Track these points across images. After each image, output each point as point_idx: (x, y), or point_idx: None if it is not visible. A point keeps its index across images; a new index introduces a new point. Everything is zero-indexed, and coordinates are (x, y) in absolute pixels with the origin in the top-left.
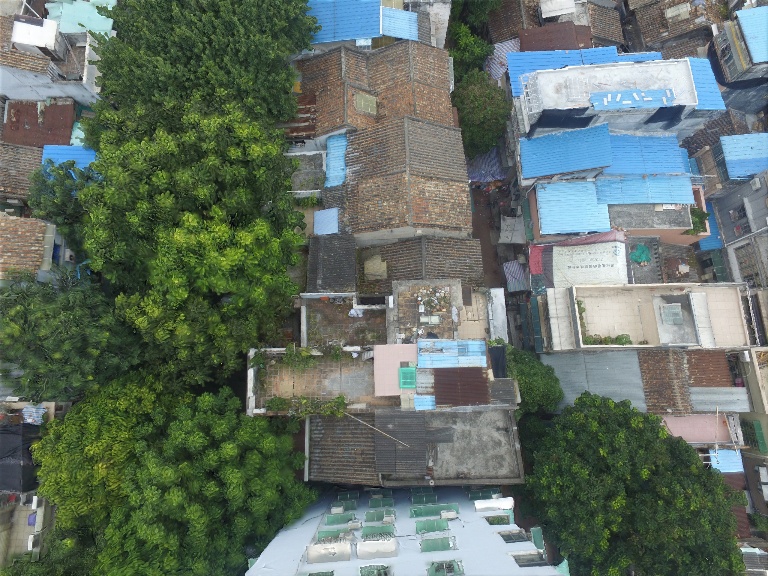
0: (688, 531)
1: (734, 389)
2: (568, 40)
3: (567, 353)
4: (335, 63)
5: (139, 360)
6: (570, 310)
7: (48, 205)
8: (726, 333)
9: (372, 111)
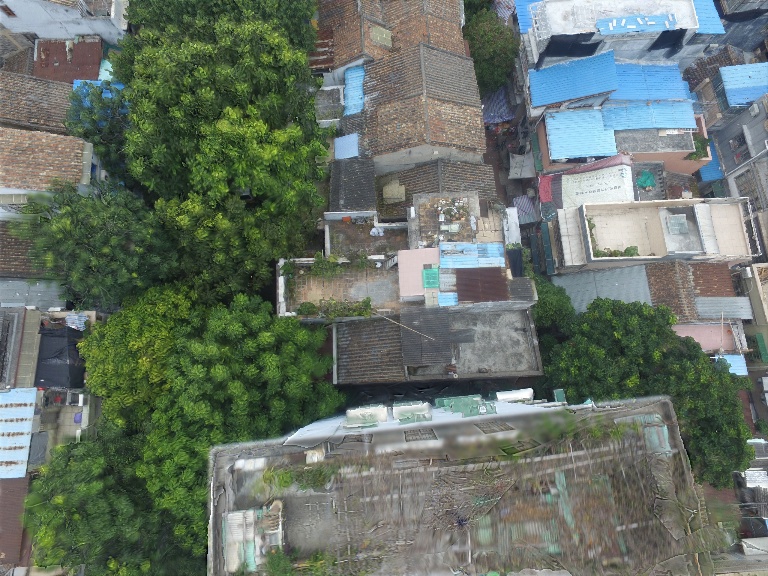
0: (699, 402)
1: (737, 298)
2: None
3: (577, 273)
4: None
5: (178, 263)
6: (580, 228)
7: (86, 122)
8: (729, 246)
9: (387, 44)
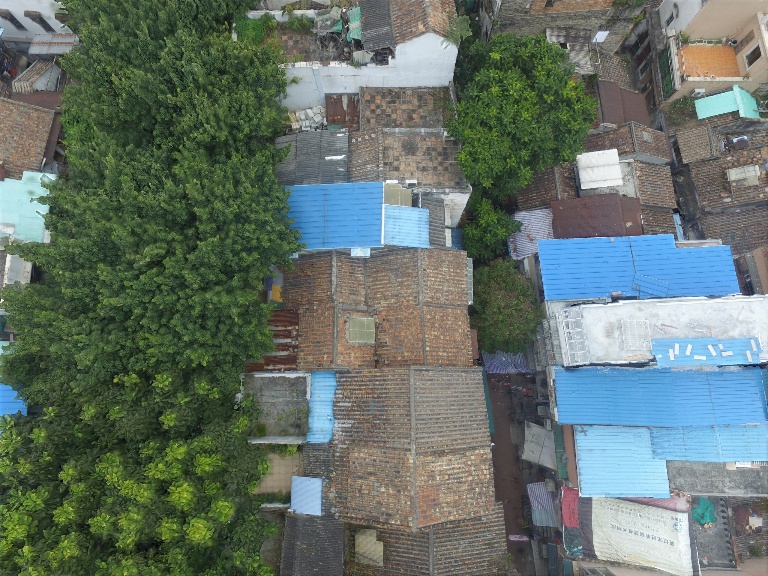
0: None
1: None
2: (613, 219)
3: None
4: (324, 271)
5: None
6: None
7: None
8: None
9: (369, 339)
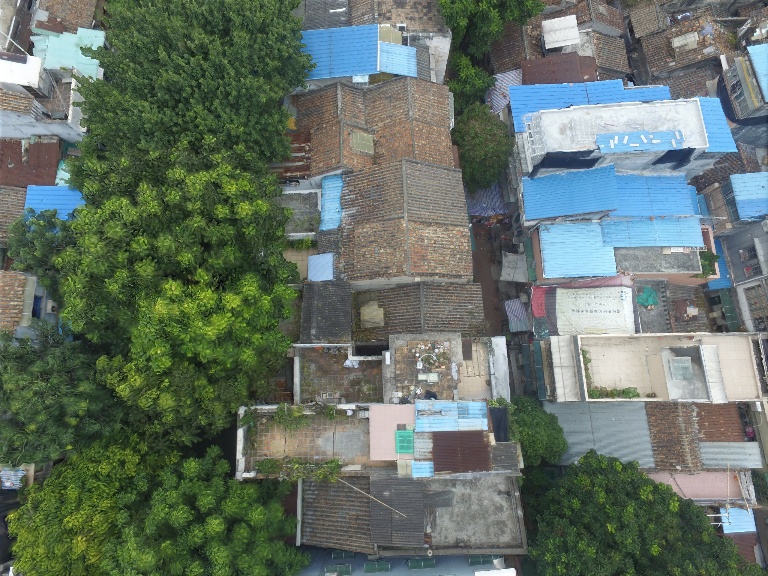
0: None
1: (746, 444)
2: (572, 72)
3: None
4: (331, 99)
5: None
6: (575, 359)
7: (28, 258)
8: (737, 385)
9: (369, 150)
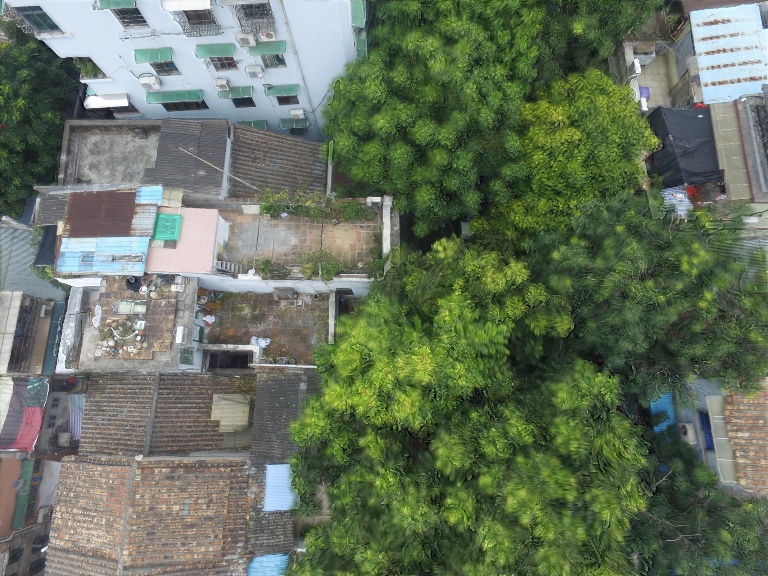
0: None
1: None
2: None
3: None
4: None
5: None
6: None
7: (742, 516)
8: None
9: None
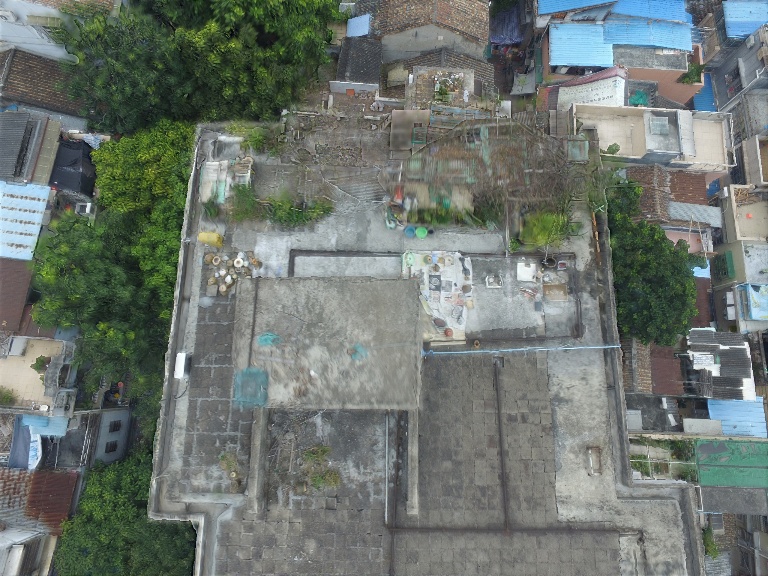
0: (650, 255)
1: (710, 207)
2: None
3: None
4: None
5: None
6: (569, 128)
7: None
8: (708, 159)
9: None
